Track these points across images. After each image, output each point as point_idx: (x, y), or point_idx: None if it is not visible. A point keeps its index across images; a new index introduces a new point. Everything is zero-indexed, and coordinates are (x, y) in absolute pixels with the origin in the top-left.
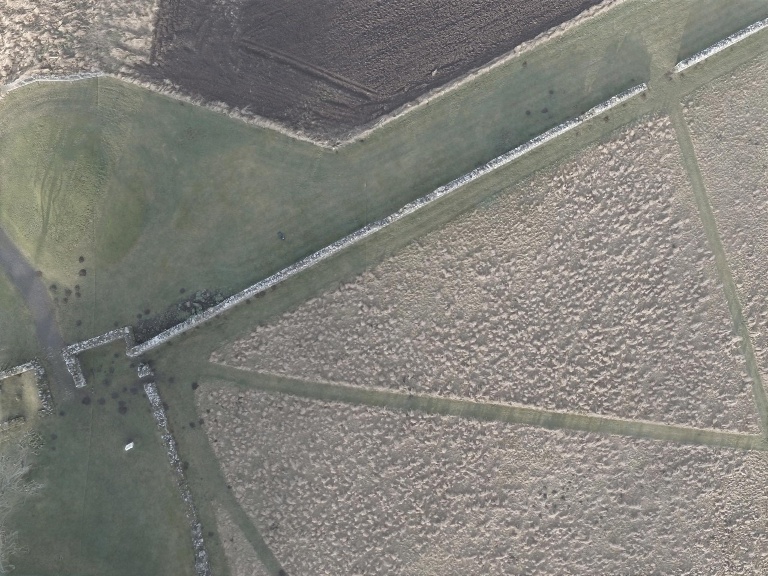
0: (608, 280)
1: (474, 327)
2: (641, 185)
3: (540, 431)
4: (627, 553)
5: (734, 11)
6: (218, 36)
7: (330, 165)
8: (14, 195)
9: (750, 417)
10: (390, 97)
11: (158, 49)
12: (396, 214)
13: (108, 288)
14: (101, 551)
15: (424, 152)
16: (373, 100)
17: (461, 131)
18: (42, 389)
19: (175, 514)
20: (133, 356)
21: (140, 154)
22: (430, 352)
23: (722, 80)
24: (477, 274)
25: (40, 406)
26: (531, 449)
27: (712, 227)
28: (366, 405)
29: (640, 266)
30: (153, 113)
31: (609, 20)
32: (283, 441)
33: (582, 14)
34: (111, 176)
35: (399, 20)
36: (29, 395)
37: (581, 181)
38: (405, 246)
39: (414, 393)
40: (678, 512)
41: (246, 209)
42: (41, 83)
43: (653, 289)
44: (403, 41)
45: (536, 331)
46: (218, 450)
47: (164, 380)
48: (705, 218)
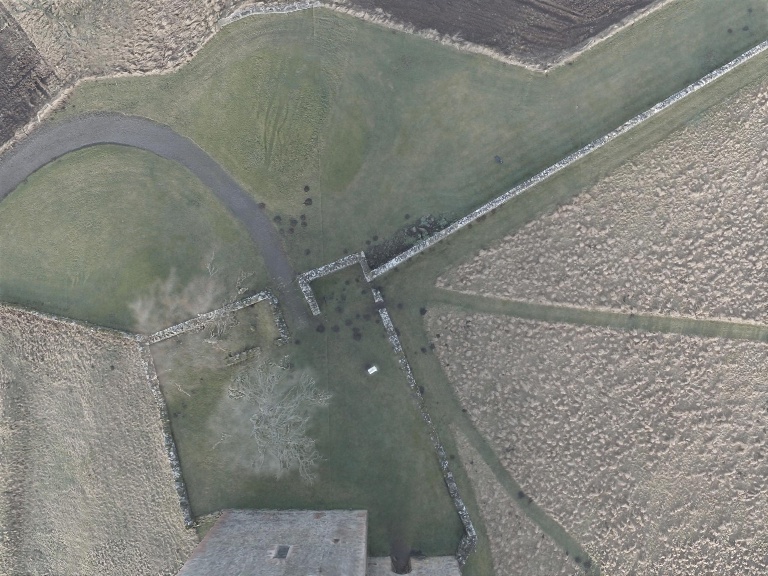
0: None
1: (690, 244)
2: None
3: (760, 346)
4: None
5: None
6: None
7: (541, 88)
8: (233, 129)
9: None
10: (595, 20)
11: None
12: (614, 133)
13: (335, 216)
14: (351, 476)
15: (632, 73)
16: (579, 23)
17: (666, 51)
18: (279, 318)
19: (419, 437)
20: (364, 283)
21: (358, 82)
22: (648, 271)
23: None
24: (690, 191)
25: (276, 335)
26: (752, 364)
27: None
28: (589, 325)
29: None
30: (368, 42)
31: None
32: (512, 363)
33: None
34: (333, 105)
35: None
36: (264, 325)
37: None
38: (619, 166)
39: (635, 312)
40: None
41: (462, 134)
42: (256, 16)
43: None
44: None
45: (750, 247)
46: (451, 374)
47: (393, 306)
48: None
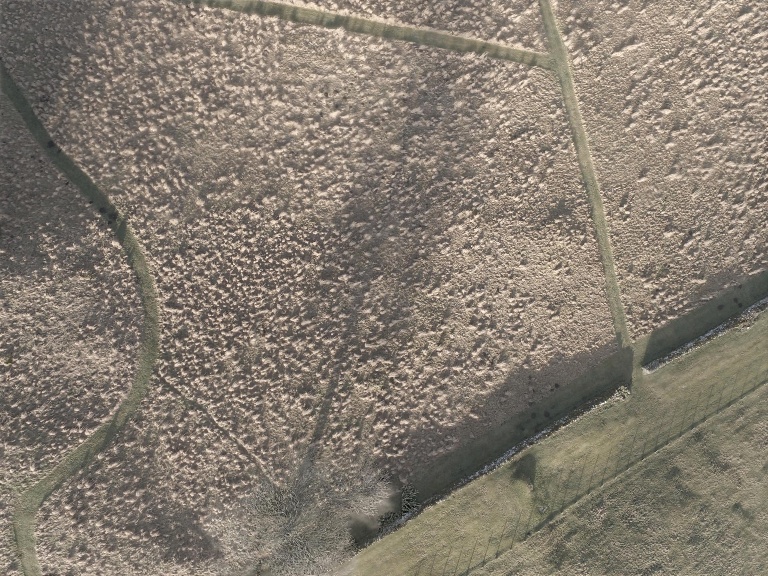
0: None
1: None
2: None
3: (322, 31)
4: (408, 155)
5: None
6: None
7: None
8: None
9: (536, 34)
10: None
11: None
12: None
13: None
14: None
15: None
16: None
17: None
18: None
19: None
20: None
21: None
22: None
23: None
24: None
25: None
26: (312, 47)
27: None
28: None
29: None
30: None
31: None
32: (58, 20)
33: None
34: None
35: None
36: None
37: None
38: None
39: None
40: (461, 121)
41: None
42: None
43: None
44: None
45: None
46: None
47: None
48: None
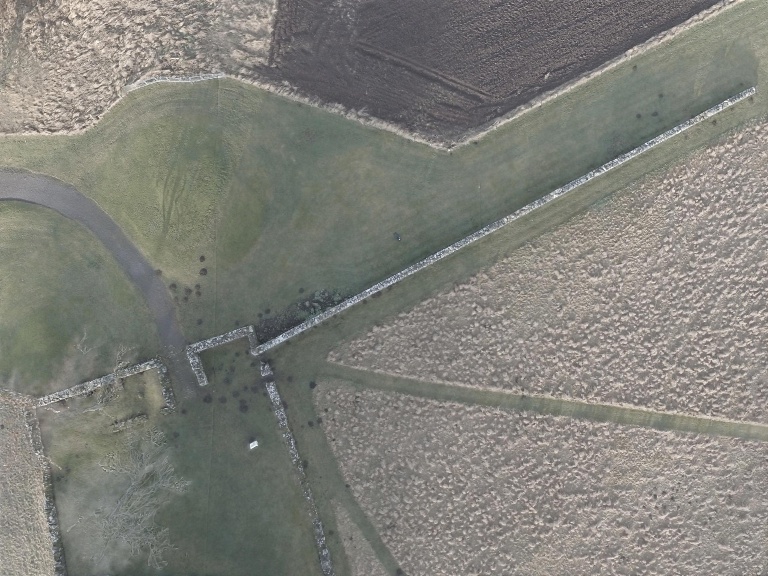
0: (717, 282)
1: (586, 328)
2: (749, 188)
3: (650, 432)
4: (736, 554)
5: None
6: (335, 38)
7: (445, 167)
8: (134, 195)
9: None
10: (503, 100)
11: (277, 51)
12: (512, 216)
13: (229, 287)
14: (226, 548)
15: (537, 154)
16: (486, 102)
17: (573, 134)
18: (166, 387)
19: (298, 512)
20: (254, 355)
21: (260, 155)
22: (542, 353)
23: None
24: (589, 276)
25: (163, 404)
26: (642, 450)
27: None
28: (480, 405)
29: (748, 269)
30: (272, 114)
31: (717, 25)
32: (399, 440)
33: (692, 19)
34: (232, 176)
35: (512, 23)
36: (152, 393)
37: (690, 184)
38: (518, 247)
39: (527, 394)
40: None
41: (362, 210)
42: (162, 84)
43: (761, 292)
44: (516, 44)
45: (646, 333)
46: (336, 449)
47: (283, 379)
48: None
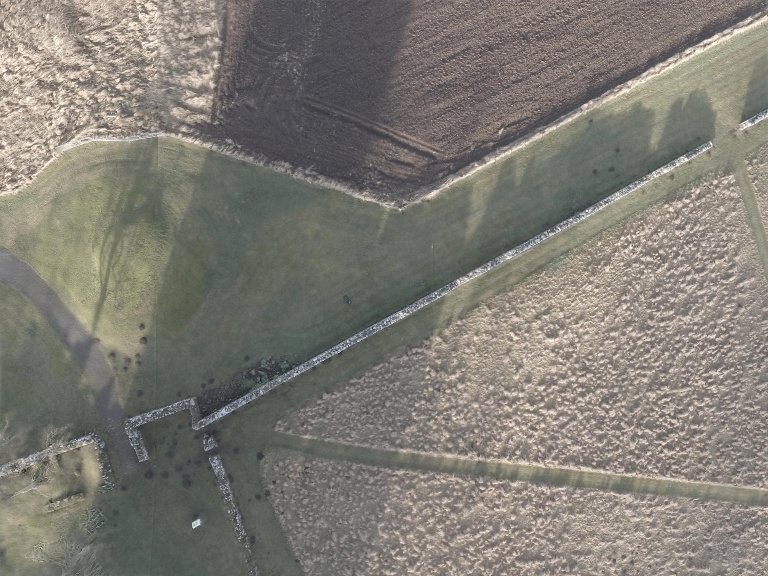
0: (675, 341)
1: (542, 390)
2: (707, 244)
3: (609, 495)
4: None
5: None
6: (281, 94)
7: (396, 226)
8: (70, 259)
9: None
10: (456, 156)
11: (219, 107)
12: (465, 278)
13: (170, 357)
14: None
15: (491, 212)
16: (439, 159)
17: (528, 191)
18: (103, 464)
19: None
20: None
21: (202, 217)
22: (498, 417)
23: None
24: (545, 337)
25: (101, 481)
26: (600, 514)
27: None
28: (434, 472)
29: (707, 326)
30: (215, 174)
31: (674, 77)
32: (351, 512)
33: (648, 72)
34: (173, 240)
35: (465, 77)
36: (89, 470)
37: (648, 240)
38: (473, 309)
39: (483, 459)
40: (745, 574)
41: (311, 272)
42: (98, 143)
43: (720, 349)
44: (469, 99)
45: (604, 393)
46: (285, 523)
47: (228, 451)
48: None
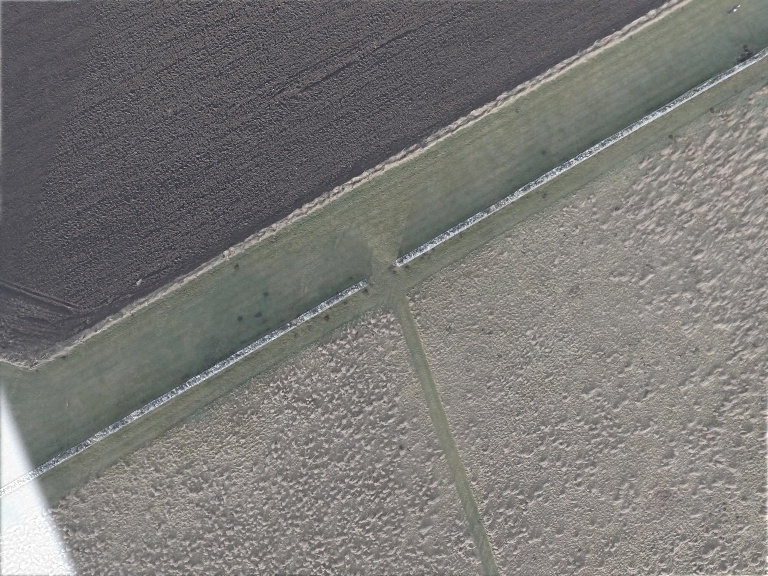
0: (331, 487)
1: (188, 545)
2: (364, 386)
3: None
4: None
5: (460, 198)
6: None
7: (30, 385)
8: None
9: None
10: (93, 309)
11: None
12: (93, 438)
13: None
14: None
15: (129, 366)
16: (75, 314)
17: (169, 342)
18: None
19: None
20: None
21: None
22: (142, 574)
23: (451, 269)
24: (188, 491)
25: None
26: None
27: (443, 423)
28: None
29: (365, 470)
30: None
31: (326, 216)
32: None
33: (294, 213)
34: None
35: (100, 229)
36: None
37: (300, 385)
38: (111, 466)
39: None
40: None
41: None
42: None
43: (379, 494)
44: (105, 251)
45: (254, 545)
46: None
47: None
48: (435, 415)
